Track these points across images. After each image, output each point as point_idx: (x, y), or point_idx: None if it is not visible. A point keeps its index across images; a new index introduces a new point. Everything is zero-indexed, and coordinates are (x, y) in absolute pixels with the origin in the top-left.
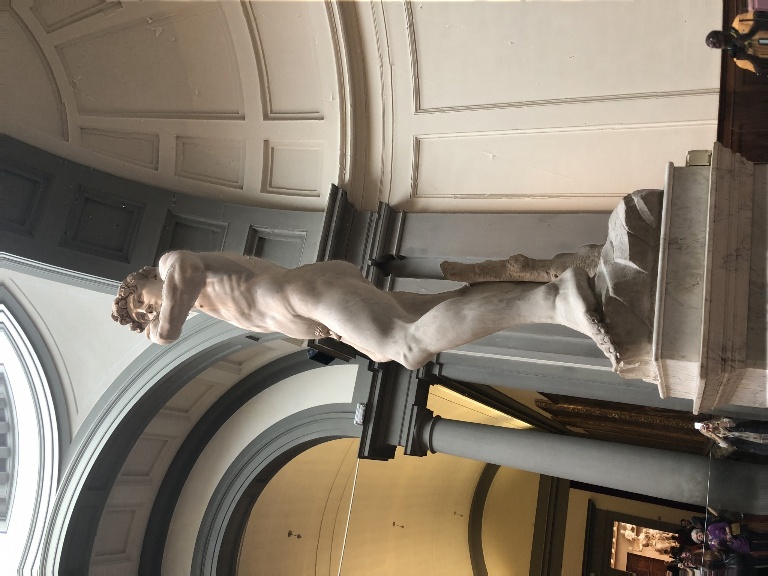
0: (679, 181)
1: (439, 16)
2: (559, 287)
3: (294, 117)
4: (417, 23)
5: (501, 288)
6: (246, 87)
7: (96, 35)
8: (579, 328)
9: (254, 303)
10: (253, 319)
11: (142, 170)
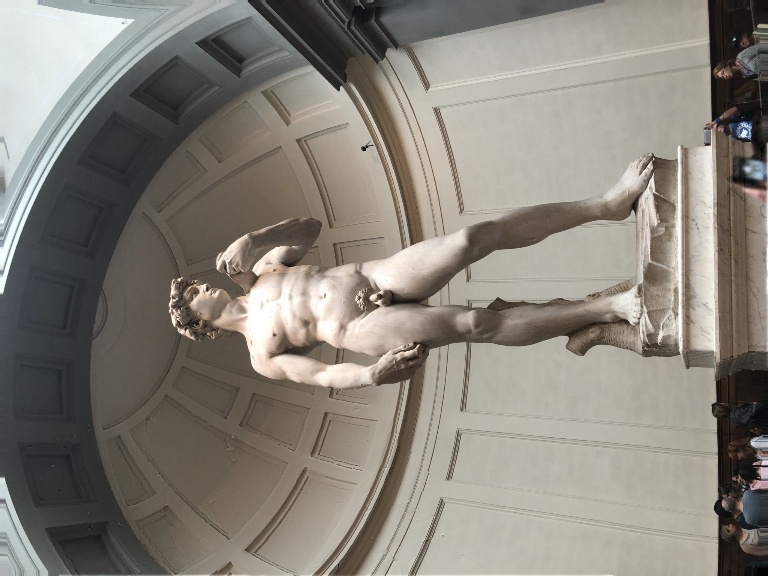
0: None
1: (455, 546)
2: None
3: (272, 564)
4: (434, 544)
5: None
6: (253, 521)
7: (194, 415)
8: (623, 185)
9: (325, 270)
10: (311, 280)
11: (118, 495)
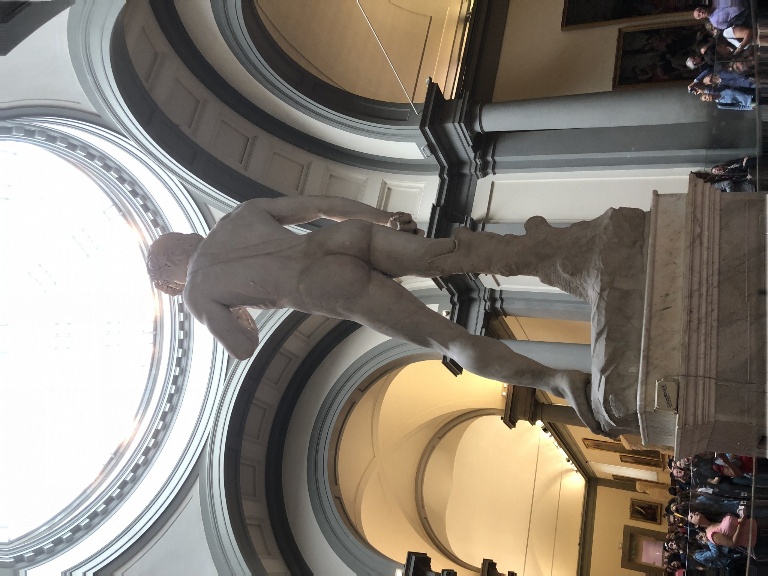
0: (650, 415)
1: None
2: (564, 396)
3: None
4: None
5: (495, 272)
6: None
7: None
8: None
9: None
10: None
11: None
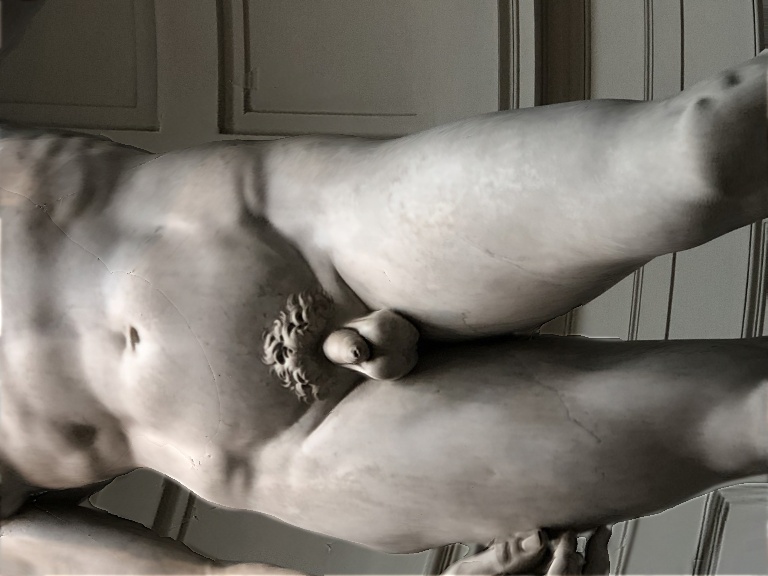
0: None
1: None
2: None
3: None
4: None
5: None
6: None
7: None
8: None
9: (109, 191)
10: (61, 254)
11: None
